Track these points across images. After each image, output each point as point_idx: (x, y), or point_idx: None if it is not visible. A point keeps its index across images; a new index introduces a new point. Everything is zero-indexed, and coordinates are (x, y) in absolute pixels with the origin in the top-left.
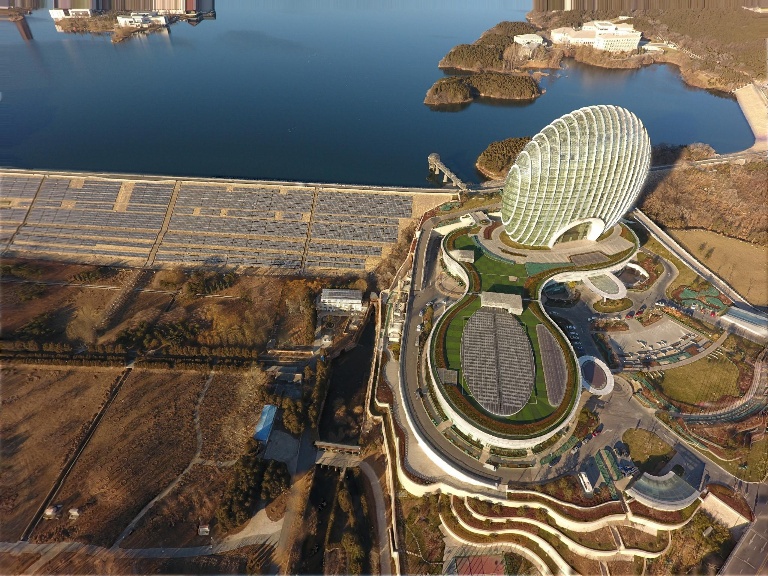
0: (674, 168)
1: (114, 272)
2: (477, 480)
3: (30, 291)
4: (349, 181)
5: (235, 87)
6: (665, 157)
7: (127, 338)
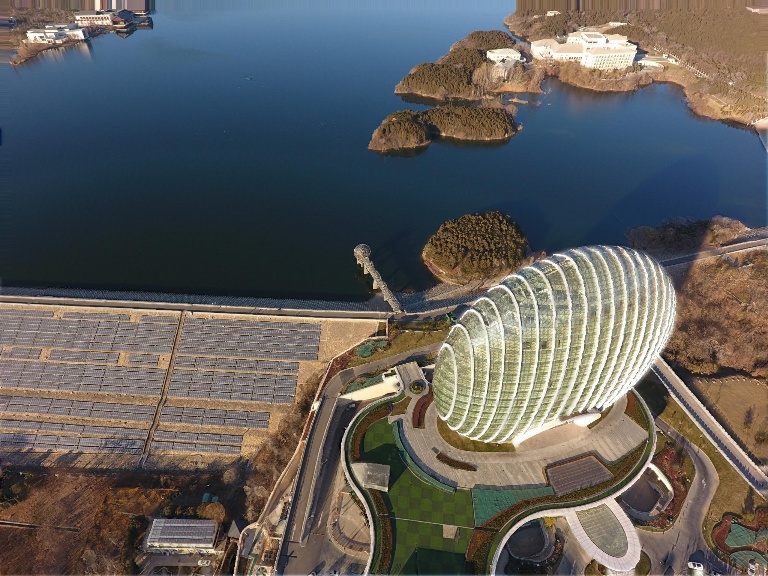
0: (693, 260)
1: None
2: None
3: None
4: (239, 291)
5: (125, 133)
6: (680, 243)
7: None
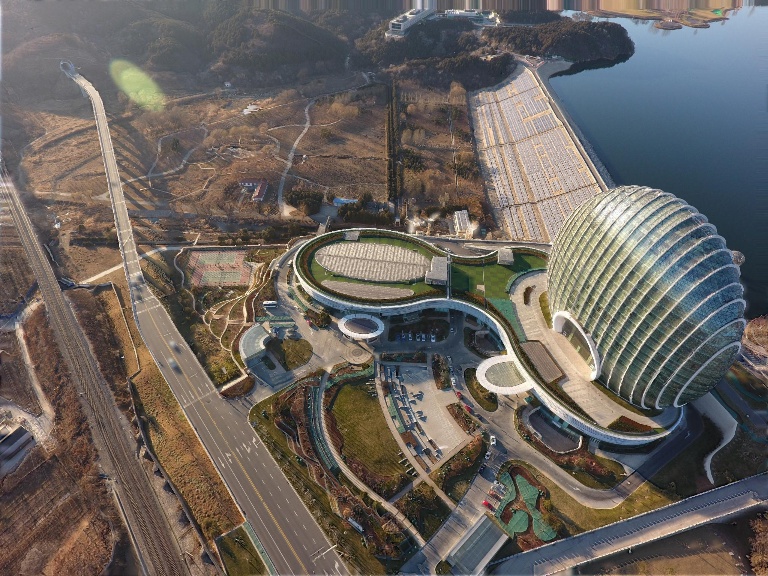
0: None
1: (469, 140)
2: (282, 257)
3: (440, 120)
4: None
5: None
6: None
7: (408, 152)
